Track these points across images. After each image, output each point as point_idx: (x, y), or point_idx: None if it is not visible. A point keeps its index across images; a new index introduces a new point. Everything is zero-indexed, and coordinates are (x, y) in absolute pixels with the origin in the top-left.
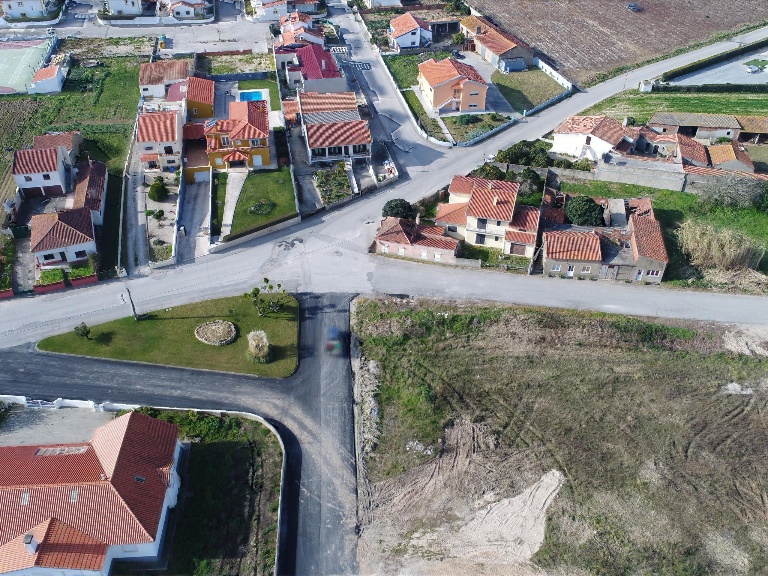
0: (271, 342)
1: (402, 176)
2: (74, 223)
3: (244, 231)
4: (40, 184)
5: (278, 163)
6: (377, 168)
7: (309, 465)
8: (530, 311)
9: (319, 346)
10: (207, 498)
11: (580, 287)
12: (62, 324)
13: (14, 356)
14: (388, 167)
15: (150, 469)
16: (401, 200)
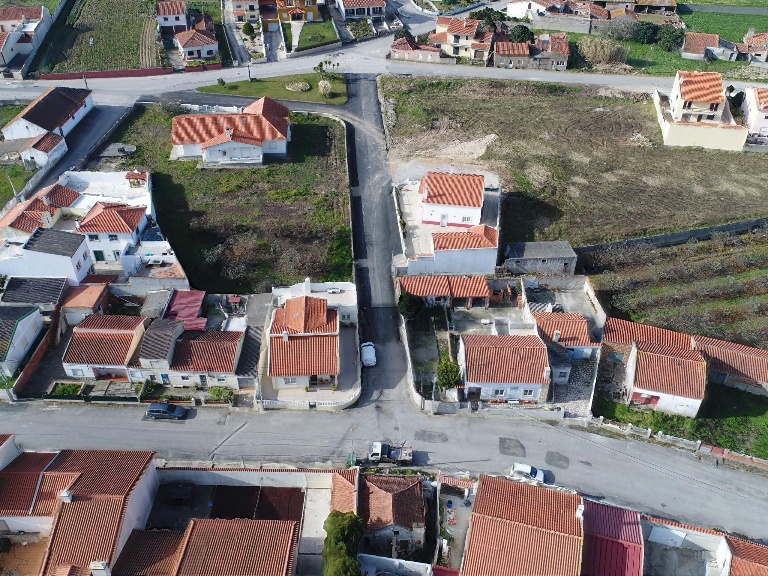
0: (331, 91)
1: (406, 28)
2: (205, 35)
3: (307, 46)
4: (173, 24)
5: (323, 18)
6: (389, 23)
7: (359, 131)
8: (485, 80)
9: (359, 93)
10: (307, 139)
11: (516, 71)
12: (207, 83)
13: (184, 93)
14: (396, 23)
15: (279, 117)
16: (406, 29)
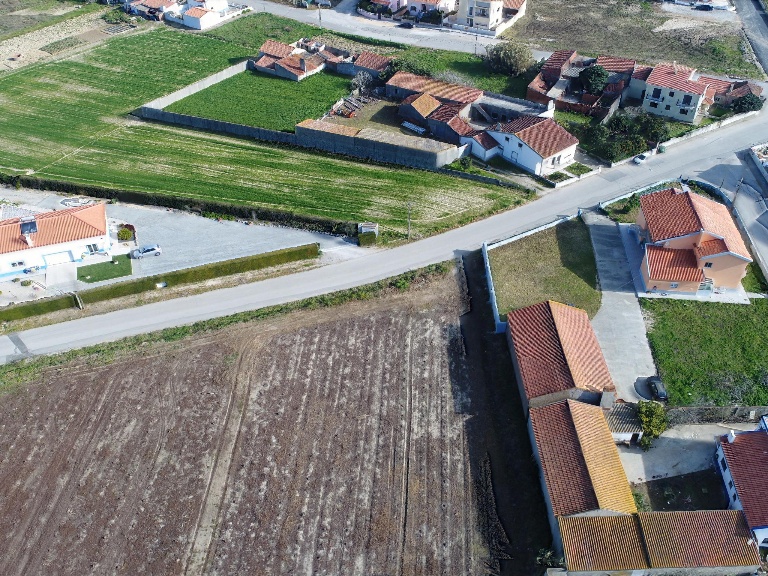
0: None
1: (746, 156)
2: None
3: None
4: None
5: None
6: None
7: None
8: None
9: None
10: None
11: None
12: None
13: None
14: None
15: None
16: (749, 94)
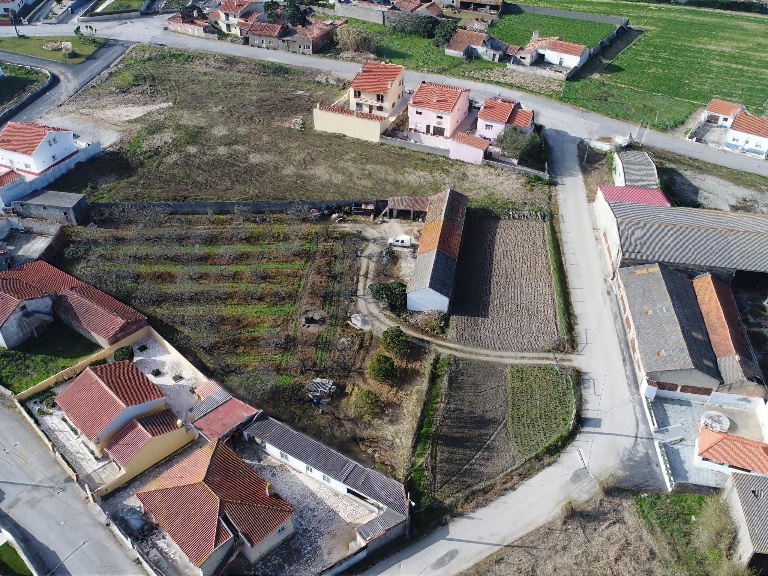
0: (78, 52)
1: None
2: None
3: (100, 12)
4: None
5: None
6: None
7: (58, 88)
8: (224, 56)
9: (102, 57)
10: None
11: (264, 51)
12: None
13: None
14: None
15: None
16: (193, 4)
